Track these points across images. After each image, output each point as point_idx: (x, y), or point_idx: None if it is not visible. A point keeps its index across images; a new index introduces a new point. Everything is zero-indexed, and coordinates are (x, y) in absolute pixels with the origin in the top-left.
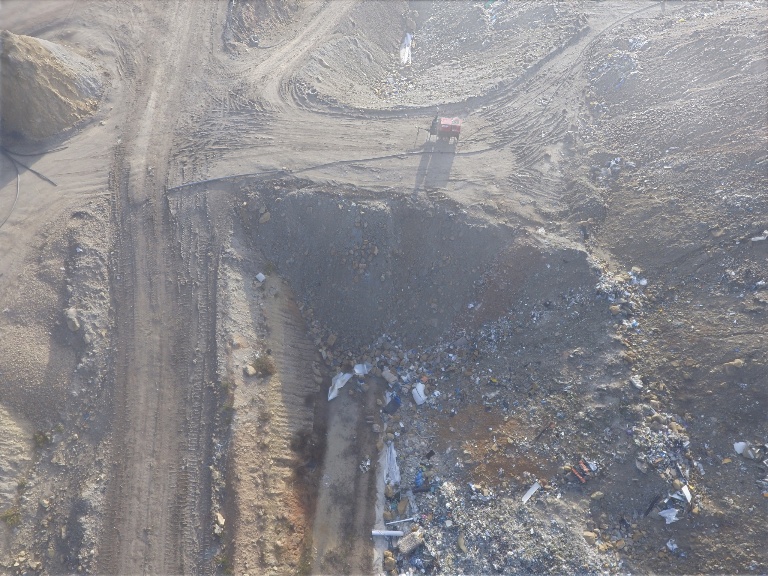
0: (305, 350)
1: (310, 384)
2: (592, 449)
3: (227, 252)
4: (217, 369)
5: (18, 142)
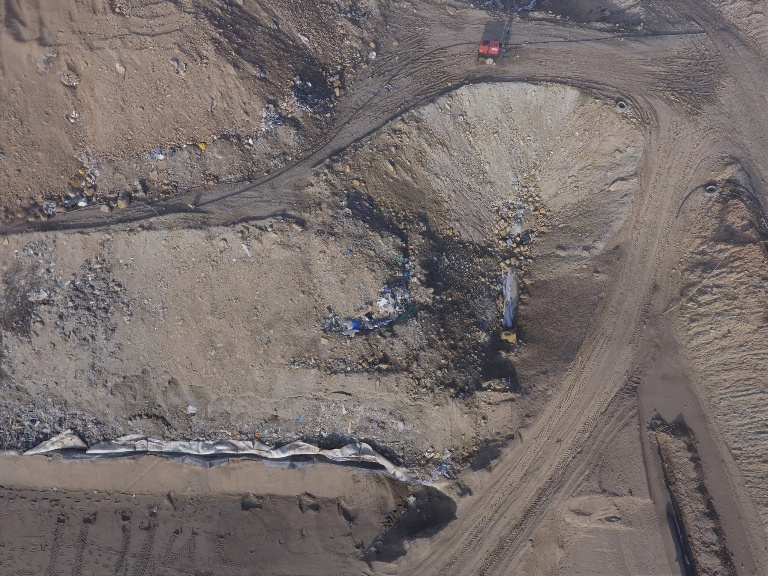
0: (559, 8)
1: None
2: None
3: (639, 6)
4: None
5: None
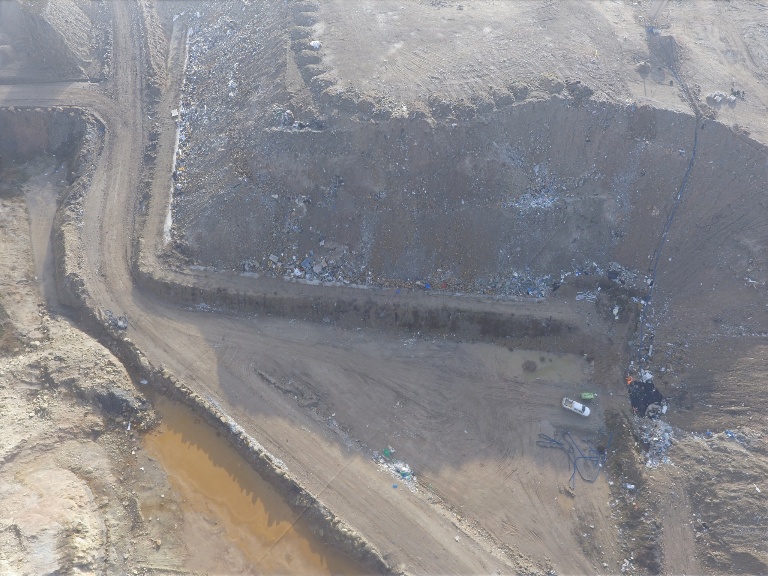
0: (164, 8)
1: (166, 15)
2: (231, 4)
3: None
4: (137, 3)
5: None
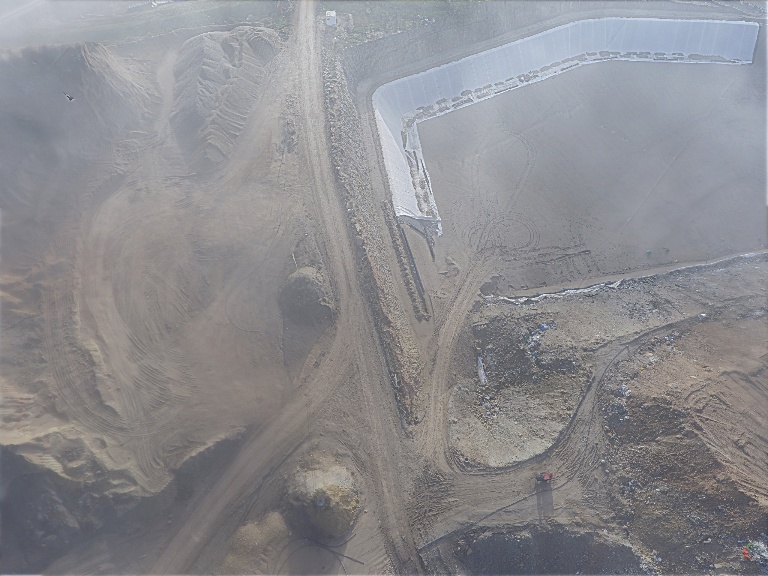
0: None
1: None
2: None
3: None
4: None
5: (332, 540)
